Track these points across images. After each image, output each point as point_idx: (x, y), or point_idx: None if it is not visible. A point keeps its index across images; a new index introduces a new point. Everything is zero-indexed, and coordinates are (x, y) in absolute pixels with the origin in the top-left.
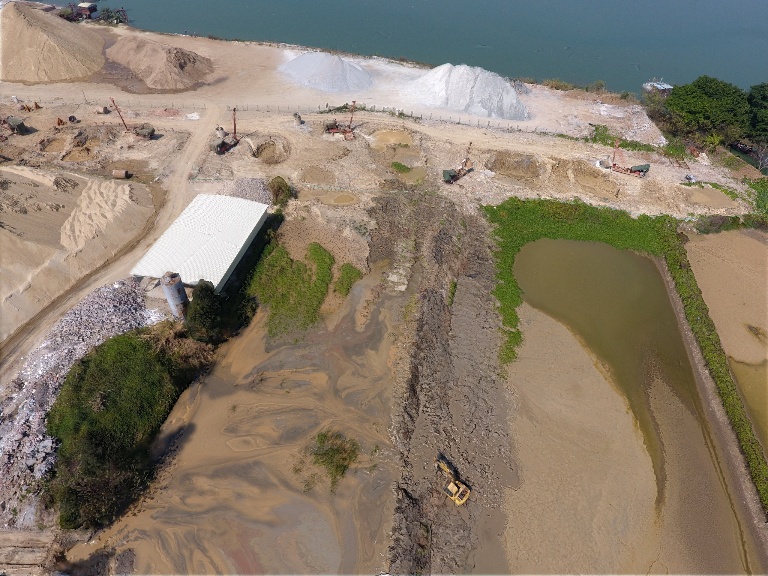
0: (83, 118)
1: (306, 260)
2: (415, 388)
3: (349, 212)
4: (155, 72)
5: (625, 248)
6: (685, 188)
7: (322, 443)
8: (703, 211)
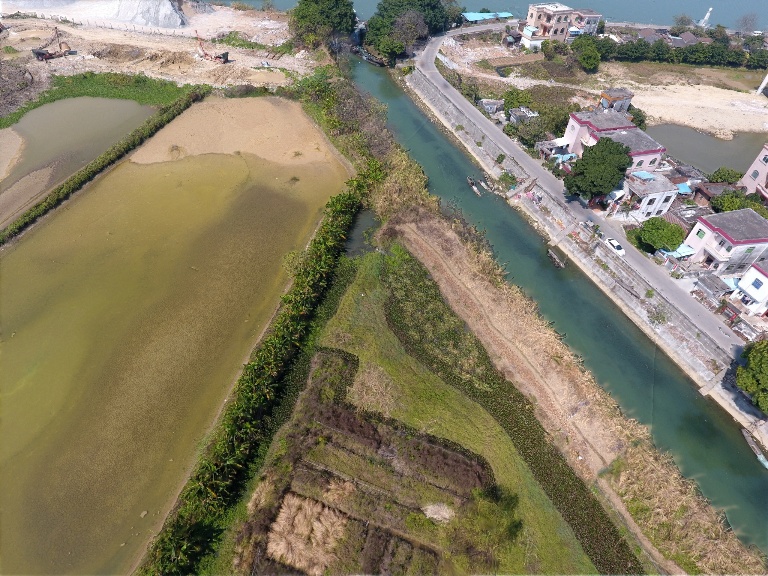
0: None
1: None
2: None
3: None
4: None
5: (146, 104)
6: (254, 71)
7: None
8: (242, 83)
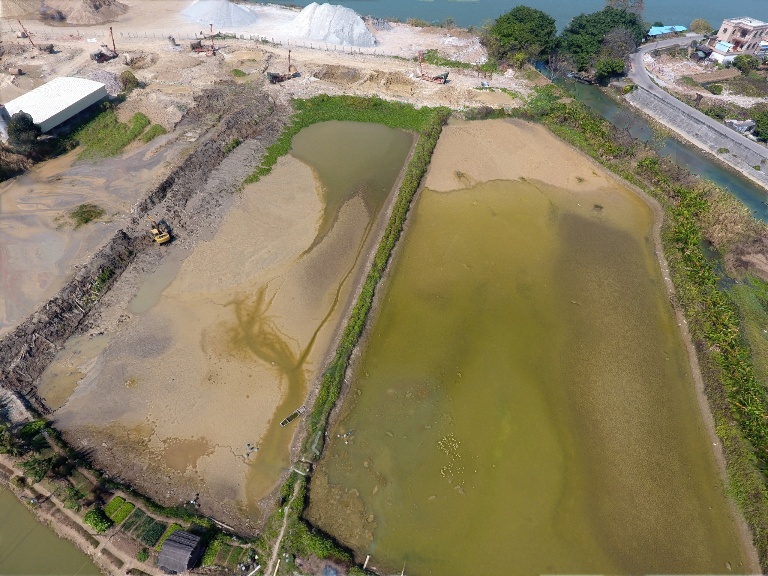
0: (5, 40)
1: (129, 122)
2: (167, 189)
3: (179, 97)
4: (74, 11)
5: (396, 127)
6: (477, 91)
7: (81, 208)
8: (478, 105)
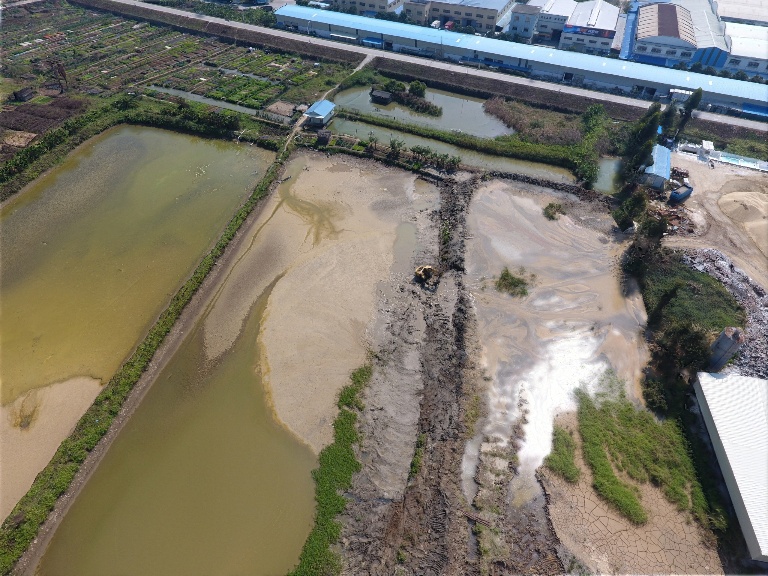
0: None
1: (634, 486)
2: (458, 333)
3: None
4: None
5: None
6: None
7: None
8: None
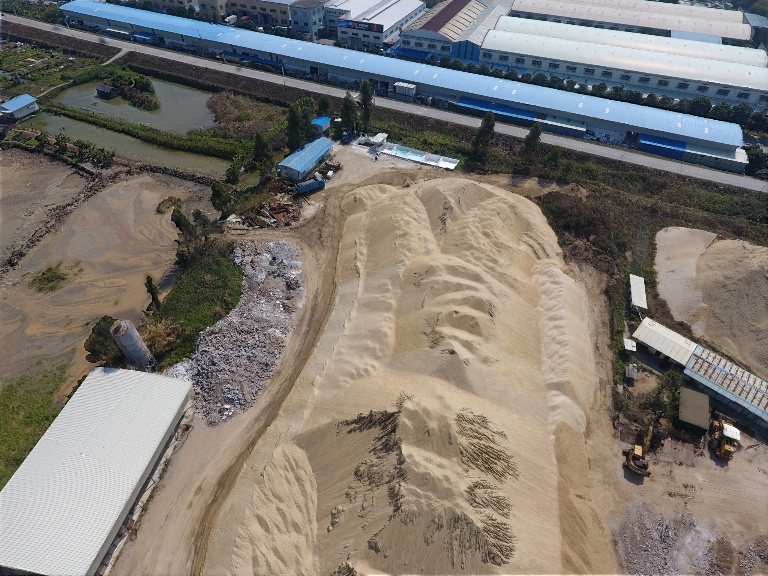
0: None
1: None
2: None
3: None
4: None
5: None
6: None
7: None
8: None
